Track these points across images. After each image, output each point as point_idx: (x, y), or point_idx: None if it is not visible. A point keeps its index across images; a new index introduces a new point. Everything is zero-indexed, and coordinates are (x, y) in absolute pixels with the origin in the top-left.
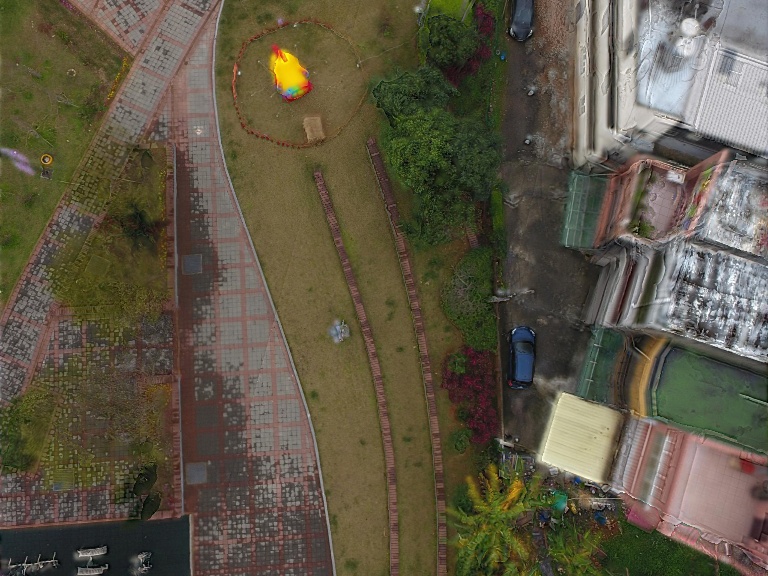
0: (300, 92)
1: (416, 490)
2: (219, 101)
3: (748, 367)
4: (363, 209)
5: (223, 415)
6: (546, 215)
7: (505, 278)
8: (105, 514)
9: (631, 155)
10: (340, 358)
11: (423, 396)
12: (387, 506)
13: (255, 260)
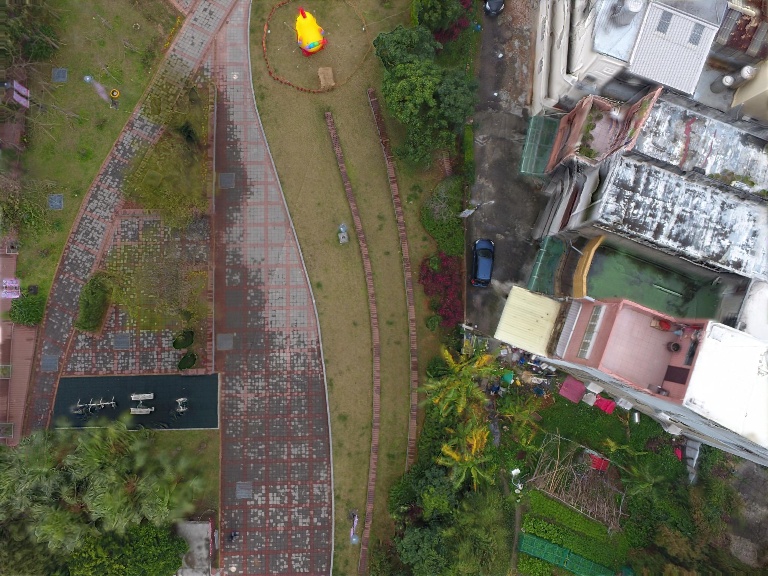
0: (316, 43)
1: (395, 362)
2: (252, 53)
3: (661, 264)
4: (363, 142)
5: (247, 298)
6: (508, 153)
7: (473, 200)
8: (153, 369)
9: (577, 95)
10: (340, 258)
11: (404, 290)
12: (372, 373)
13: (276, 179)
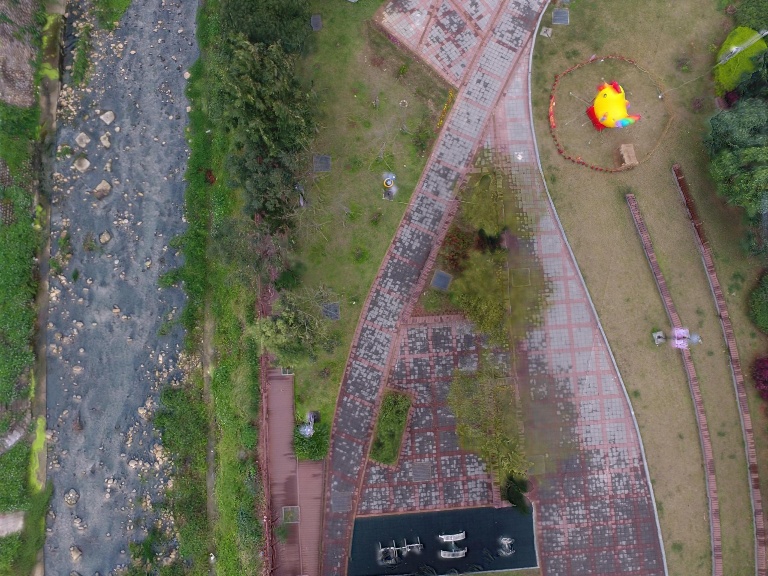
0: (632, 121)
1: (732, 480)
2: (537, 130)
3: None
4: (672, 228)
5: (557, 413)
6: None
7: None
8: (460, 503)
9: None
10: (658, 362)
11: (734, 396)
12: (706, 494)
13: (577, 274)
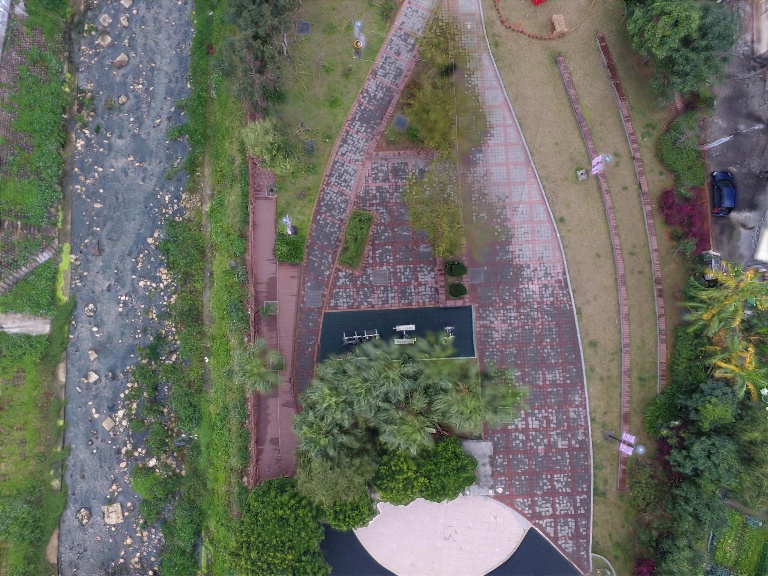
0: None
1: (640, 290)
2: (484, 4)
3: None
4: (595, 85)
5: (495, 234)
6: (733, 91)
7: None
8: (412, 302)
9: None
10: (580, 194)
11: (643, 222)
12: (618, 302)
13: (515, 121)
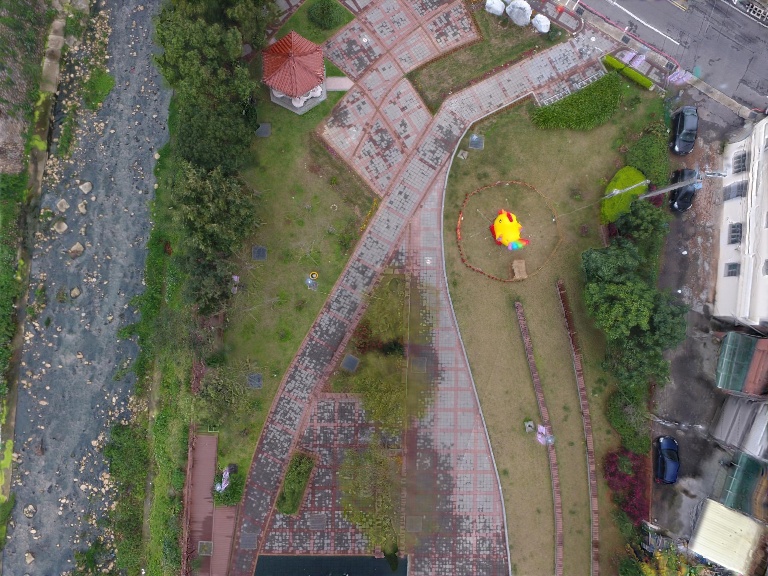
0: (520, 246)
1: (577, 550)
2: (446, 239)
3: None
4: (551, 333)
5: (436, 482)
6: (689, 350)
7: (656, 397)
8: (347, 550)
9: None
10: (526, 446)
11: (587, 480)
12: (554, 560)
13: (467, 366)
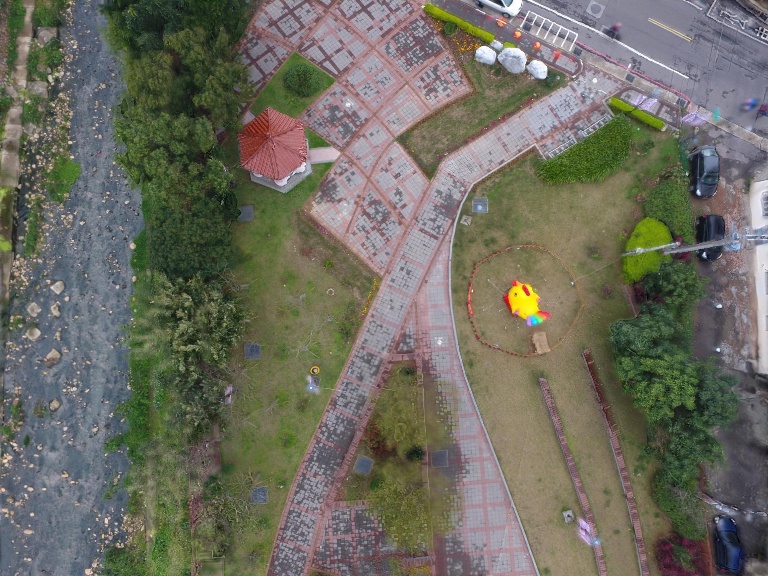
0: (540, 321)
1: None
2: (456, 315)
3: None
4: (582, 410)
5: None
6: None
7: (705, 470)
8: None
9: None
10: (567, 539)
11: (638, 572)
12: None
13: (493, 455)
